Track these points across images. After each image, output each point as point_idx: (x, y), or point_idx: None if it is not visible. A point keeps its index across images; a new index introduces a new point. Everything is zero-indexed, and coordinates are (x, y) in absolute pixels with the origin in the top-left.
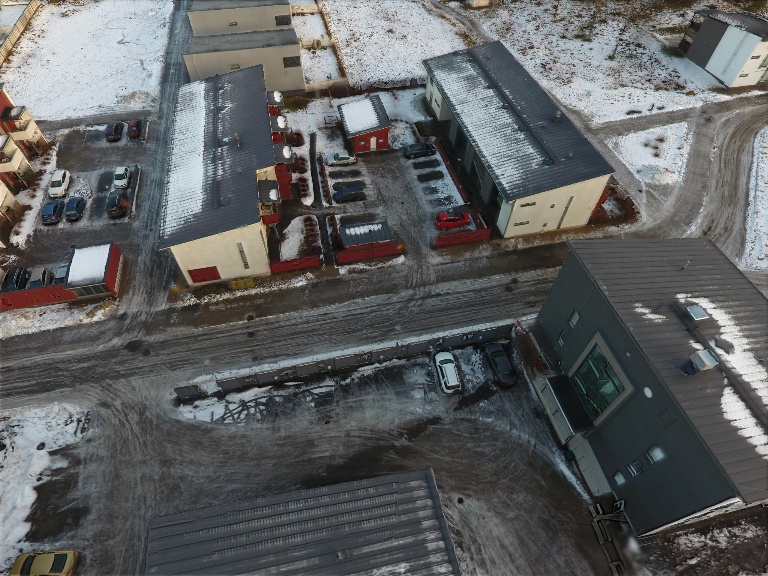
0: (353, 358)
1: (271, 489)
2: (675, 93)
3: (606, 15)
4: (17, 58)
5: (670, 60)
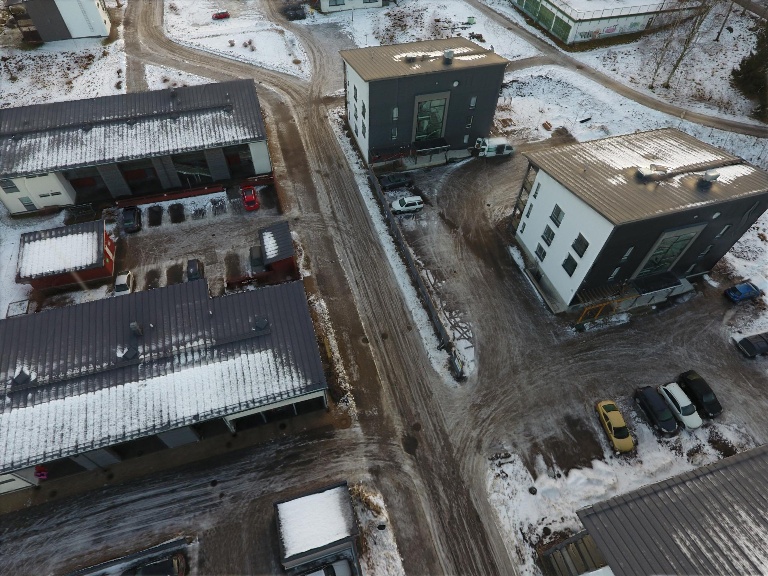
0: None
1: (512, 296)
2: (99, 61)
3: None
4: None
5: (43, 50)
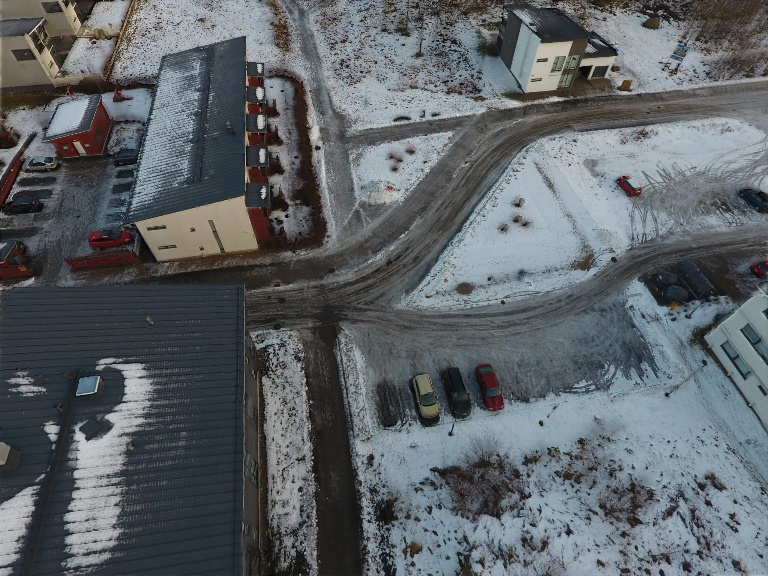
0: None
1: None
2: (464, 97)
3: (443, 6)
4: None
5: (481, 59)
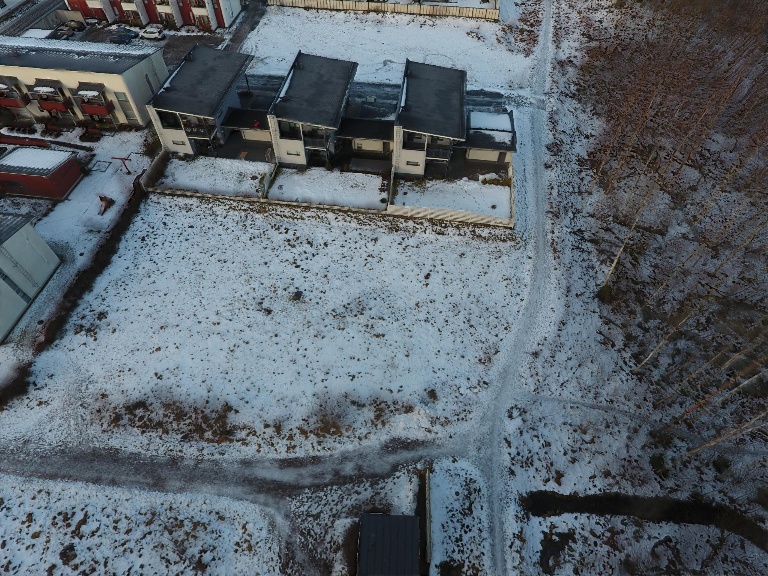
0: None
1: None
2: None
3: None
4: (374, 16)
5: None
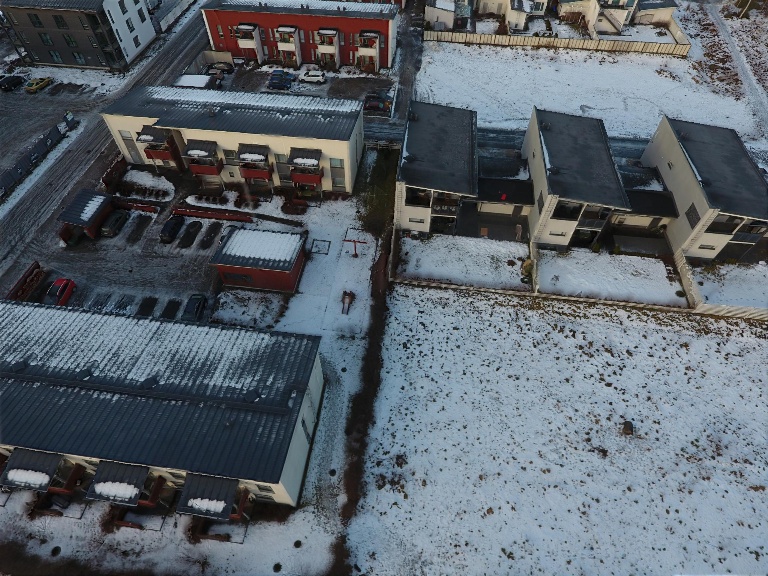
0: (3, 182)
1: None
2: None
3: None
4: (545, 53)
5: None
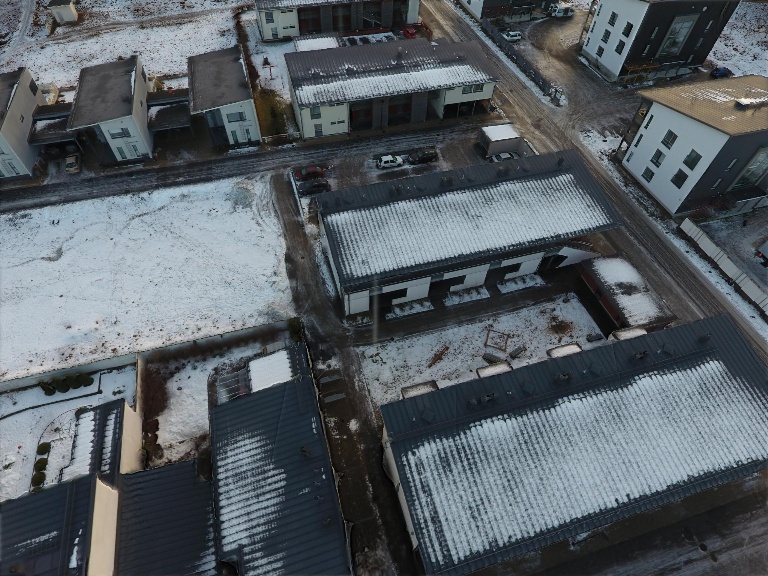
0: None
1: (583, 76)
2: None
3: None
4: None
5: None
